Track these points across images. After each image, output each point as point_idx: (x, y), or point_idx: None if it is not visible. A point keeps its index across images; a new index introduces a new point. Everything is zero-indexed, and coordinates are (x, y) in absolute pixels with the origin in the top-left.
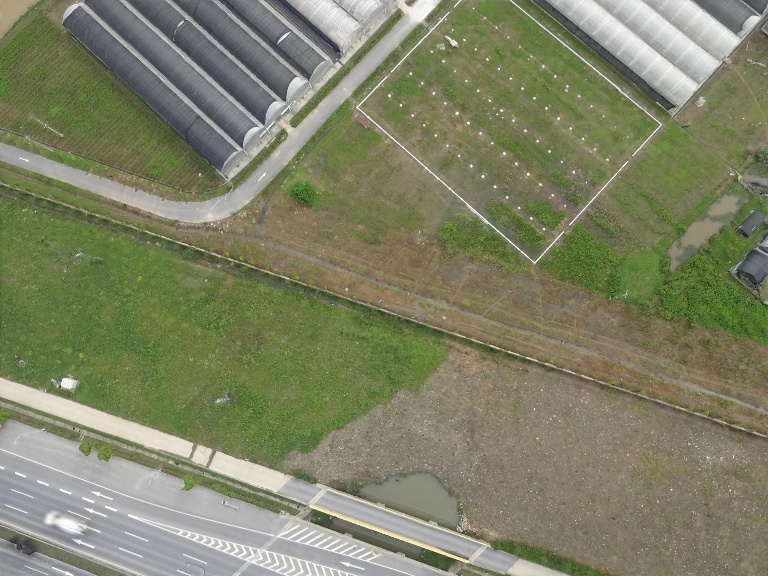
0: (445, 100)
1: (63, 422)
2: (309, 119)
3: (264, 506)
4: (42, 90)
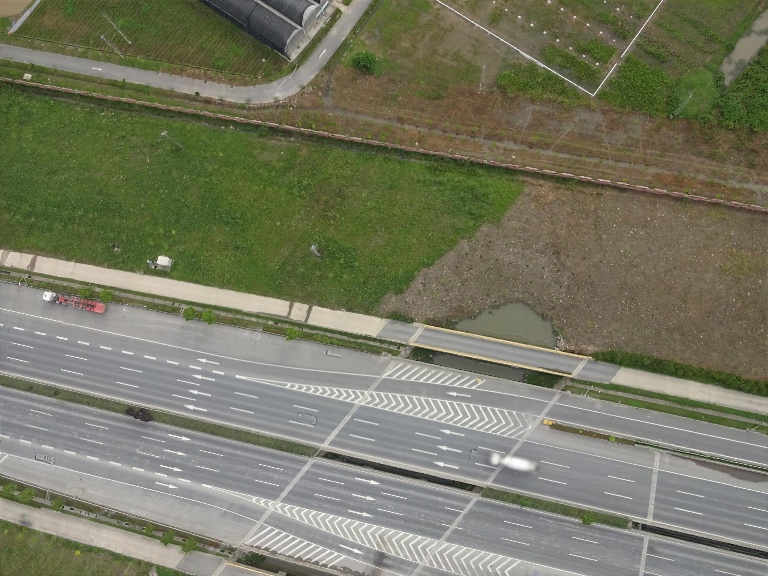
0: None
1: (162, 299)
2: None
3: (366, 349)
4: (106, 5)
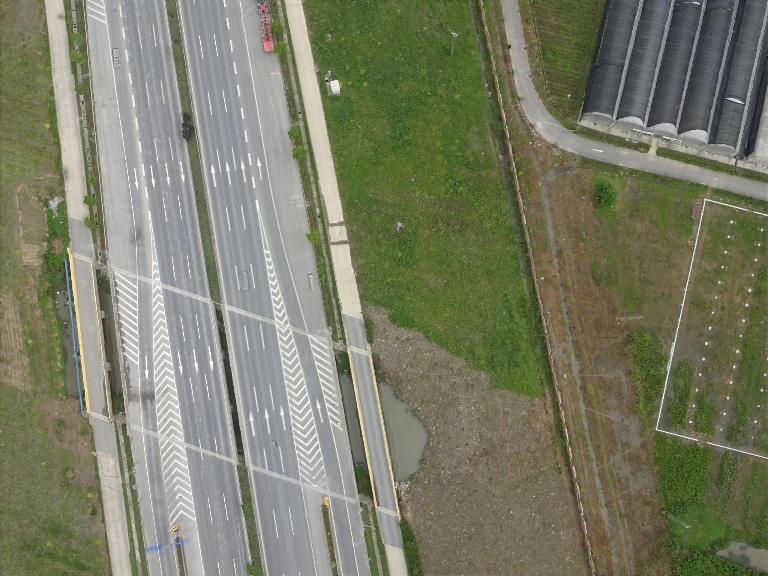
0: (756, 273)
1: (300, 101)
2: (671, 163)
3: (328, 310)
4: None
